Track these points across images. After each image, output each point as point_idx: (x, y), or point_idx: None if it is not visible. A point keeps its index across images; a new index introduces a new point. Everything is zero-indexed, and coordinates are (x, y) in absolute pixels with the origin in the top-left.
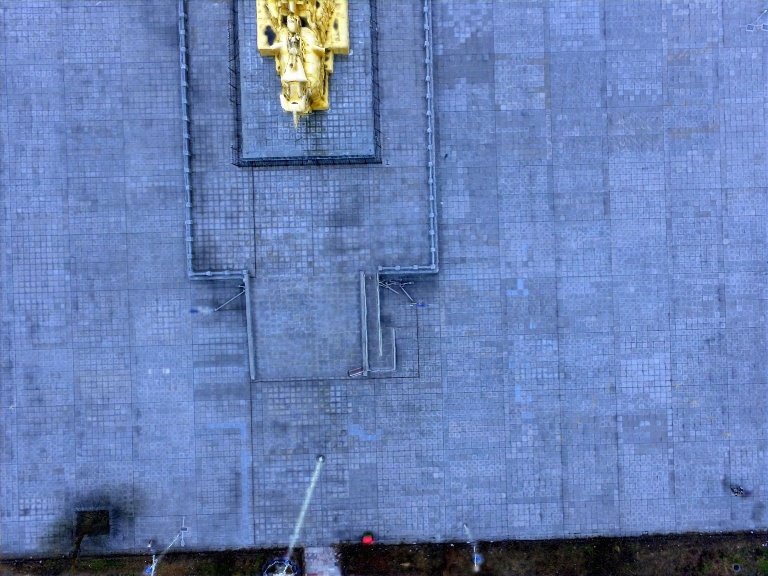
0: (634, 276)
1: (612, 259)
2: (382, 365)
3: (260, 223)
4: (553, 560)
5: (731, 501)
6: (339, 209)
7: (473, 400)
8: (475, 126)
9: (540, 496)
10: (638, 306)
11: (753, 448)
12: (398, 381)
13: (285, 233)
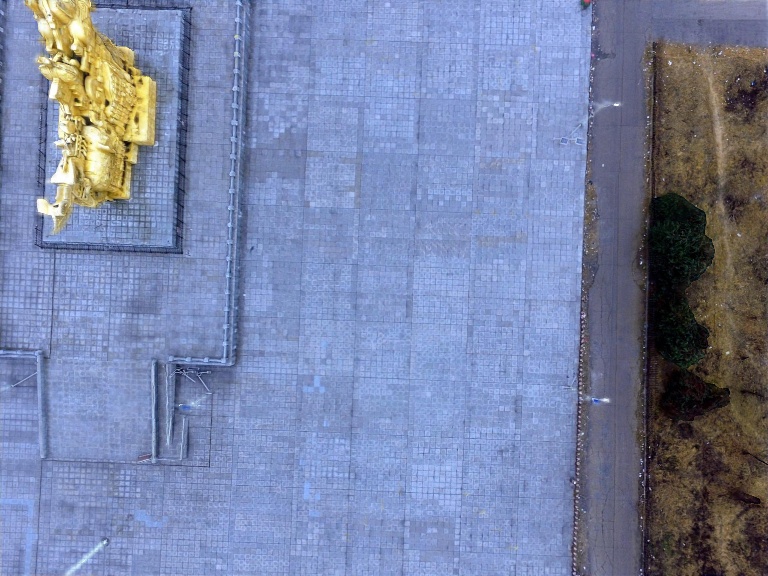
0: (432, 381)
1: (411, 362)
2: (172, 453)
3: (58, 305)
4: None
5: None
6: (137, 296)
7: (261, 494)
8: (283, 221)
9: None
10: (434, 411)
11: (540, 564)
12: (188, 469)
13: (82, 316)
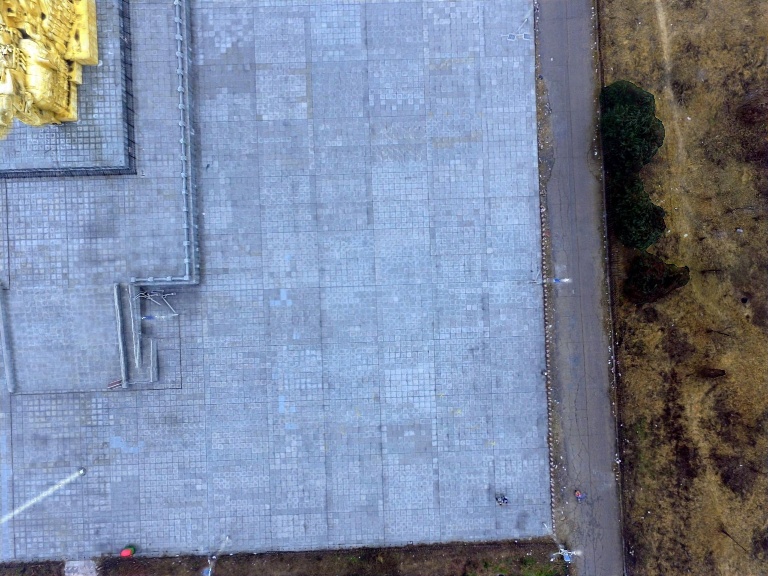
0: (398, 286)
1: (376, 269)
2: (143, 377)
3: (14, 235)
4: (315, 571)
5: (496, 510)
6: (94, 220)
7: (236, 411)
8: (237, 136)
9: (304, 507)
10: (402, 316)
11: (517, 457)
12: (160, 393)
13: (39, 245)
